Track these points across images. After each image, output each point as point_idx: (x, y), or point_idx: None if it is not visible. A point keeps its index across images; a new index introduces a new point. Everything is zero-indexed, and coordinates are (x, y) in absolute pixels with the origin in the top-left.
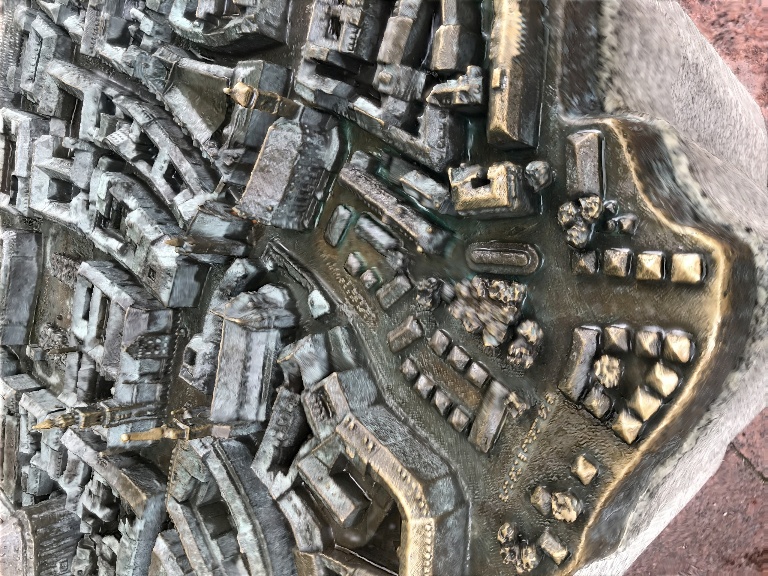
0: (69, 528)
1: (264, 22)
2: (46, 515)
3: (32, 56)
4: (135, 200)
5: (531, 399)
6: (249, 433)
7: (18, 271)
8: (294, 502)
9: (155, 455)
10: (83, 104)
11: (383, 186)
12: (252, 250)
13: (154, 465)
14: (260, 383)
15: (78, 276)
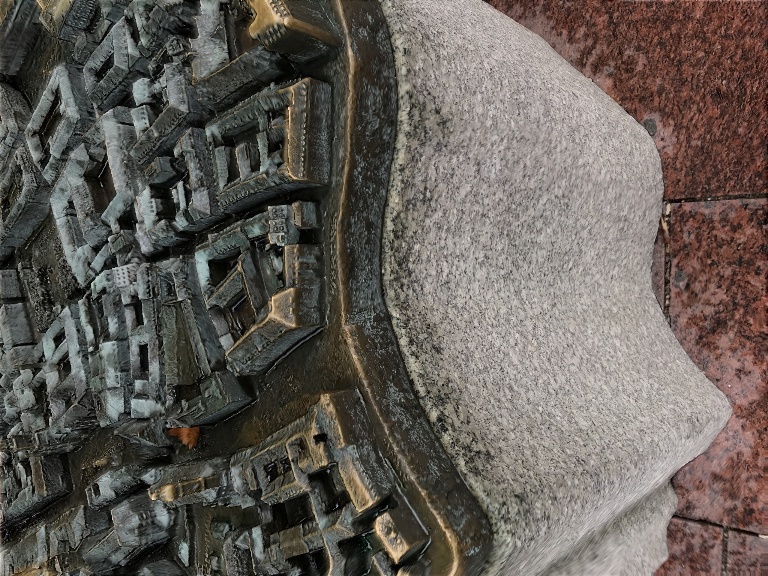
0: (3, 421)
1: (248, 371)
2: None
3: (103, 54)
4: (117, 325)
5: None
6: (108, 570)
7: (30, 210)
8: None
9: (70, 452)
10: (113, 199)
11: (246, 575)
12: (174, 454)
13: (67, 458)
14: (128, 553)
15: (59, 318)
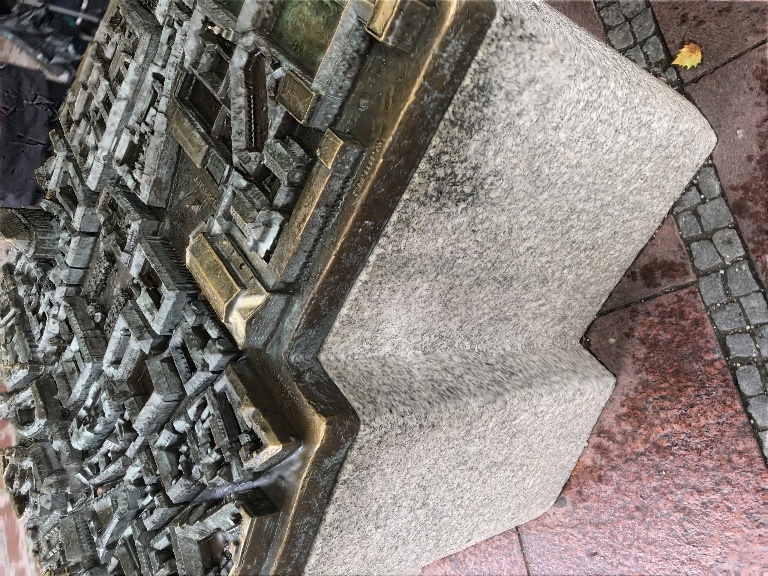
0: None
1: None
2: (42, 256)
3: None
4: None
5: (48, 564)
6: None
7: None
8: (28, 465)
9: None
10: (131, 420)
11: None
12: None
13: None
14: None
15: None
